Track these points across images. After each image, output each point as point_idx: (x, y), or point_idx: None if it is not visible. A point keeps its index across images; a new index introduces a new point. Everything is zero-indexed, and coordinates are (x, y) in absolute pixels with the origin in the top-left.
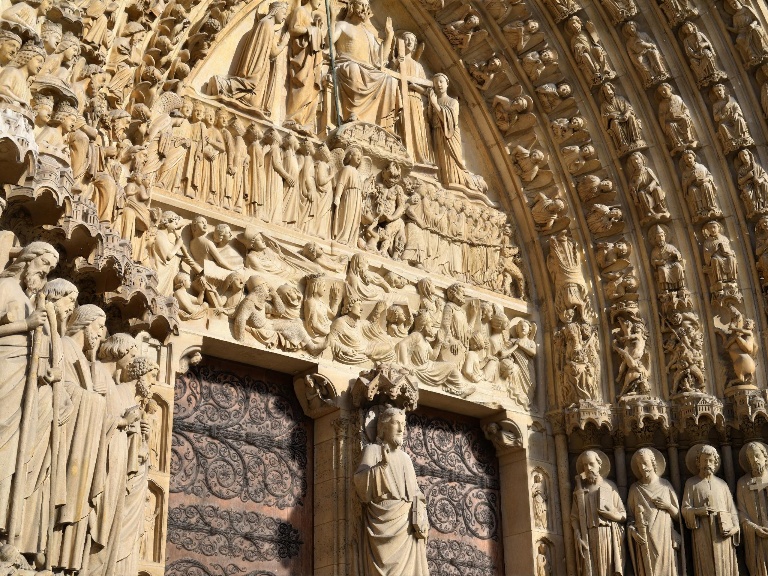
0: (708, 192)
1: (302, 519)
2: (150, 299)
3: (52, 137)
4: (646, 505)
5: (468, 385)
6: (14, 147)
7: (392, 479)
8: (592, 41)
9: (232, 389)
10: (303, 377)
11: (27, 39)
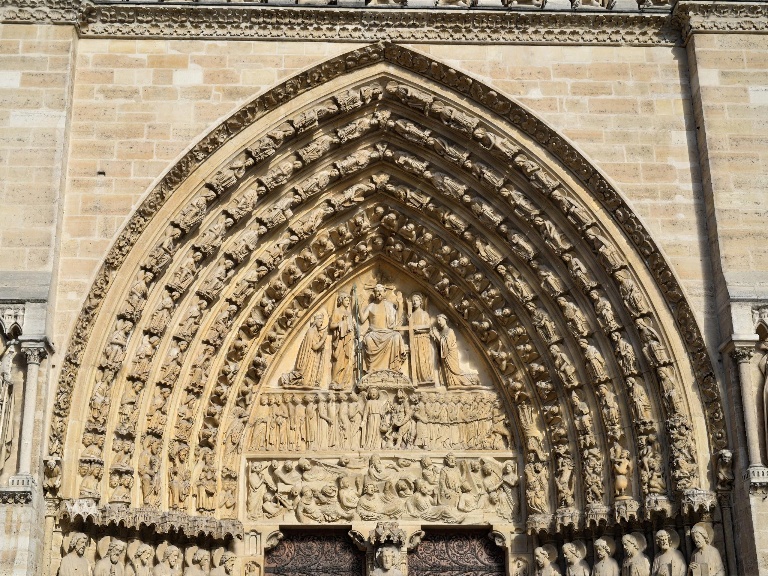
0: (594, 366)
1: None
2: (207, 533)
3: (119, 492)
4: None
5: (462, 515)
6: (82, 516)
7: None
8: (514, 278)
9: (314, 544)
10: None
11: (92, 462)
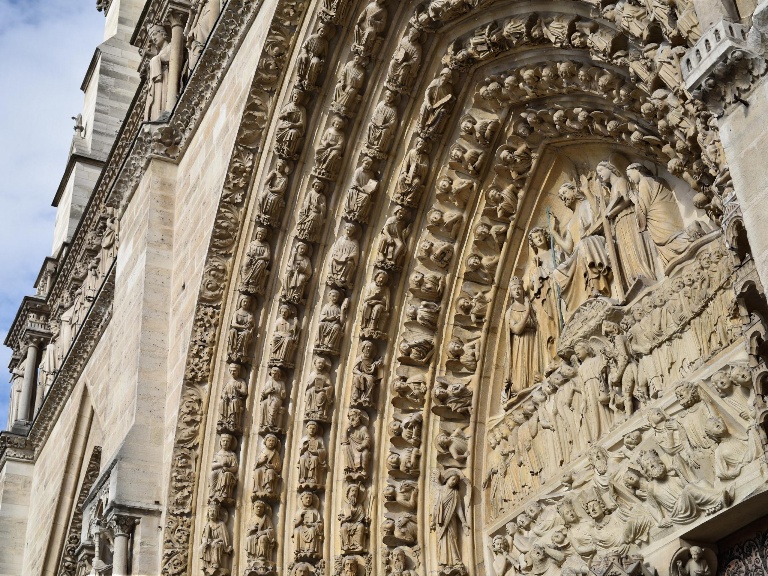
0: (664, 80)
1: None
2: None
3: None
4: None
5: (727, 488)
6: None
7: None
8: None
9: None
10: None
11: None
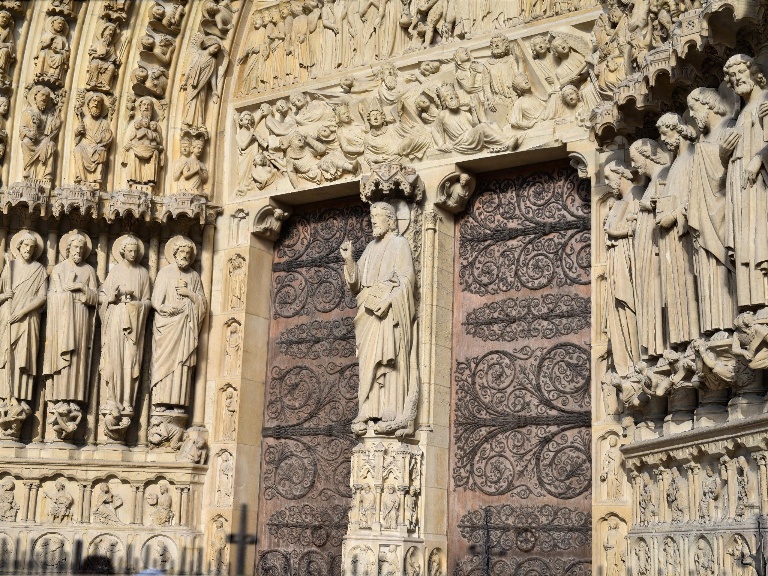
0: None
1: None
2: (122, 211)
3: None
4: None
5: (517, 136)
6: None
7: None
8: None
9: (335, 222)
10: None
11: None
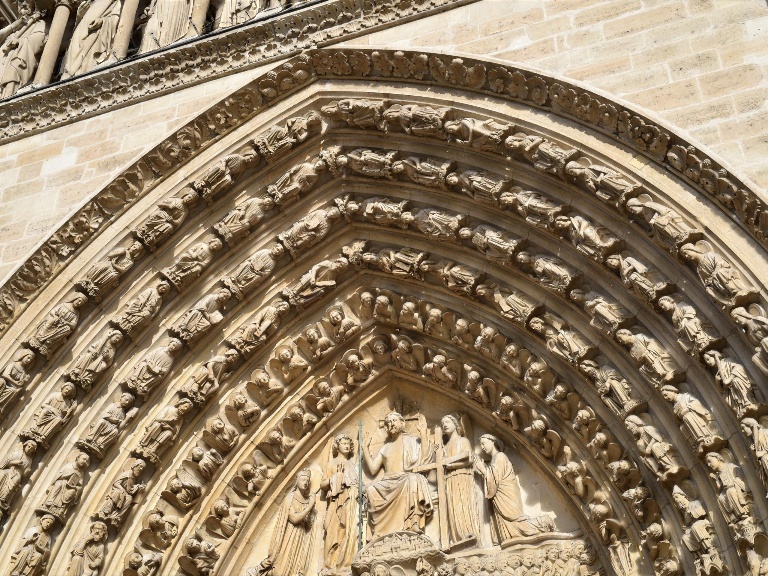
0: (689, 424)
1: None
2: None
3: None
4: None
5: None
6: None
7: None
8: (557, 331)
9: None
10: None
11: None
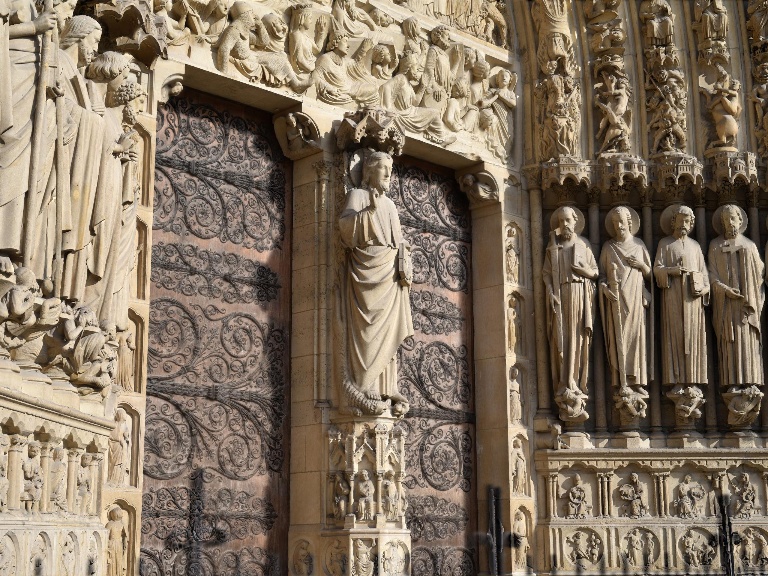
0: None
1: (280, 263)
2: (144, 15)
3: None
4: (620, 263)
5: (449, 134)
6: None
7: (378, 225)
8: None
9: (211, 124)
10: (285, 115)
11: None
